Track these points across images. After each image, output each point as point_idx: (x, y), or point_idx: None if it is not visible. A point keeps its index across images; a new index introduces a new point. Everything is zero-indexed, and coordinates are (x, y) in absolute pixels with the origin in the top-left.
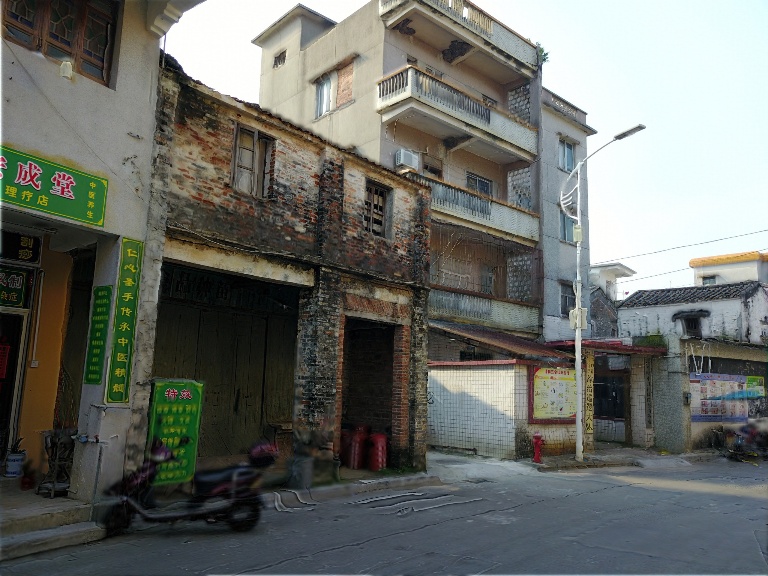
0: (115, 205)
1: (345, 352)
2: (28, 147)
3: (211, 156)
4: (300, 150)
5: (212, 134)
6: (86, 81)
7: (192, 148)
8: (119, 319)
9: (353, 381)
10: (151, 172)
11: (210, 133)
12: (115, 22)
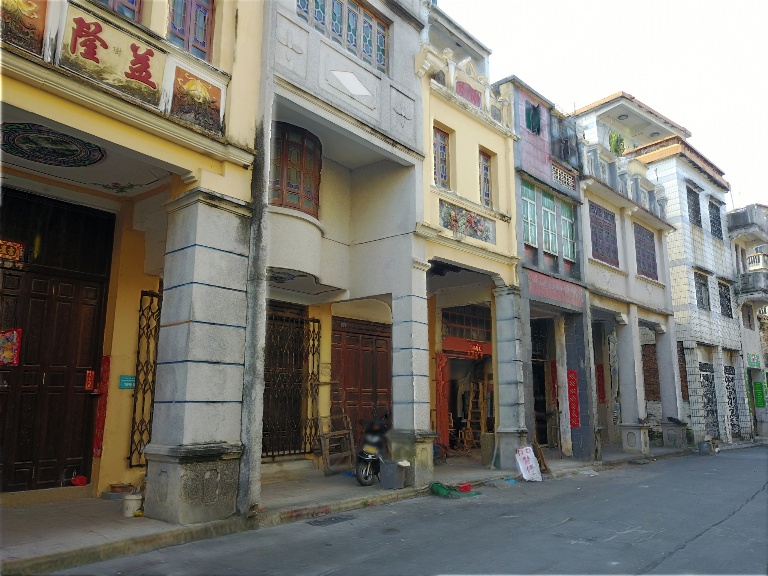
0: (760, 361)
1: None
2: (752, 352)
3: None
4: None
5: (764, 333)
6: None
7: (762, 339)
8: (765, 391)
9: None
10: (761, 350)
11: (763, 333)
12: (750, 312)
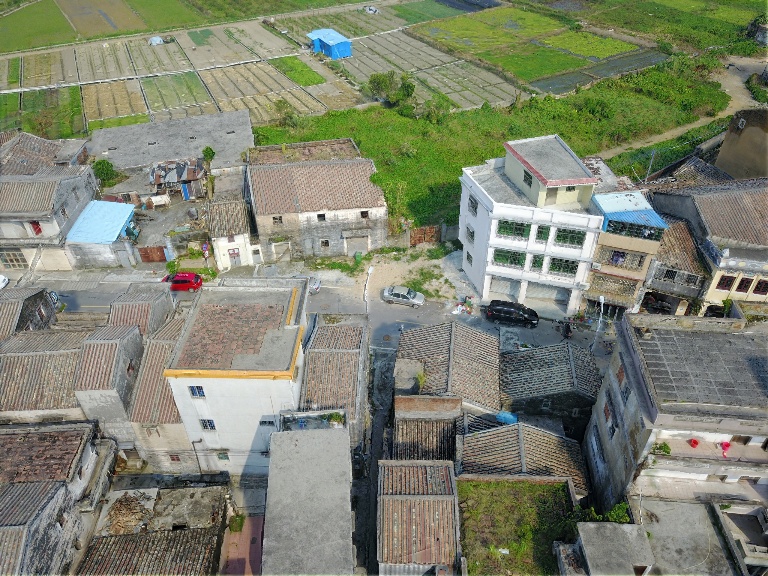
0: None
1: None
2: None
3: None
4: None
5: None
6: None
7: None
8: None
9: None
10: None
11: None
12: None
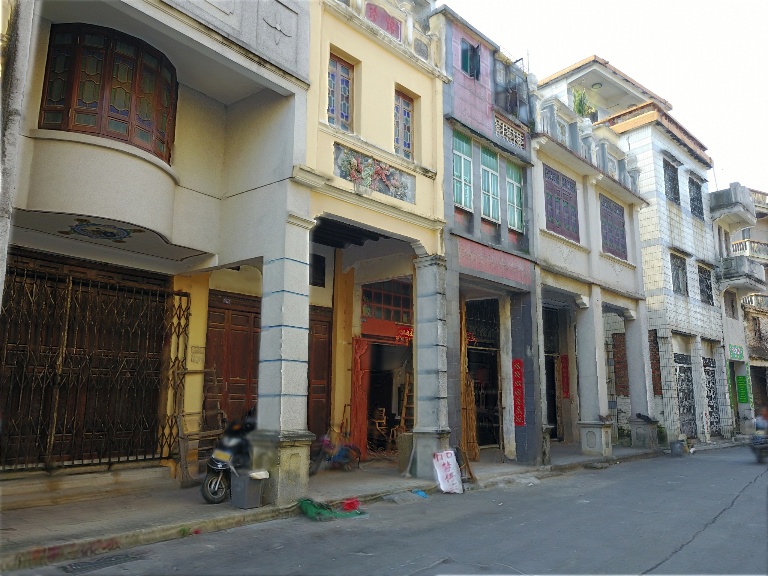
0: None
1: (758, 388)
2: (735, 344)
3: (749, 330)
4: (764, 319)
5: (748, 323)
6: (736, 321)
7: (746, 329)
8: None
9: (764, 400)
10: (745, 341)
11: (748, 322)
12: (733, 299)
